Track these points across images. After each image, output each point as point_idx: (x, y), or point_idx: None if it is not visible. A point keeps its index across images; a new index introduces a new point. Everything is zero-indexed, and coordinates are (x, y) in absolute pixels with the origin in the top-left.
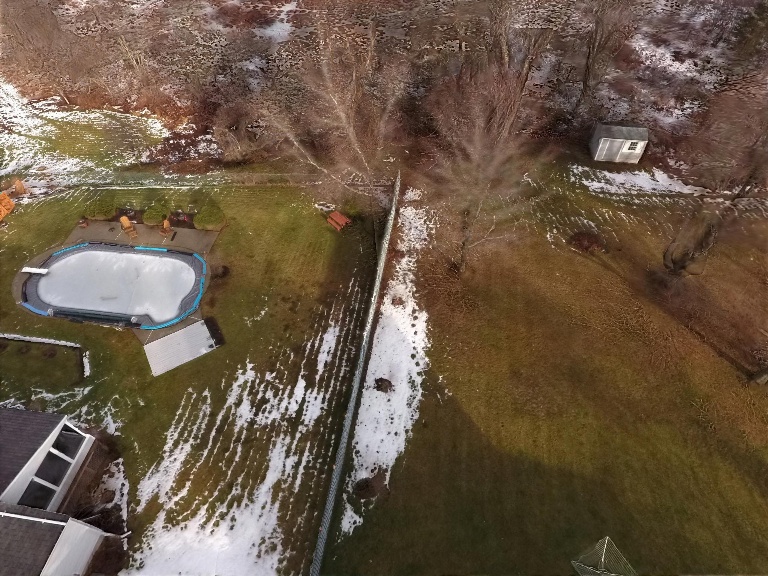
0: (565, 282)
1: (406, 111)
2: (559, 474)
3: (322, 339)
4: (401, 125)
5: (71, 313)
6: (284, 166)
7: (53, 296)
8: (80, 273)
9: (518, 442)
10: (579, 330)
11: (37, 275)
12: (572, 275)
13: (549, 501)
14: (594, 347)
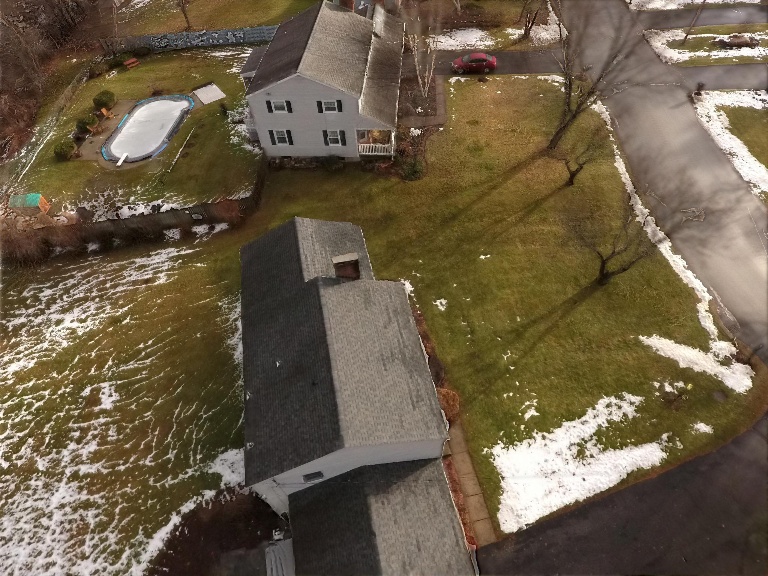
0: (207, 6)
1: (4, 71)
2: (291, 5)
3: (219, 56)
4: (44, 48)
5: (171, 132)
6: (51, 99)
7: (150, 148)
8: (133, 143)
9: (279, 11)
10: (234, 2)
11: (126, 159)
12: (203, 5)
13: (299, 5)
14: (243, 0)
